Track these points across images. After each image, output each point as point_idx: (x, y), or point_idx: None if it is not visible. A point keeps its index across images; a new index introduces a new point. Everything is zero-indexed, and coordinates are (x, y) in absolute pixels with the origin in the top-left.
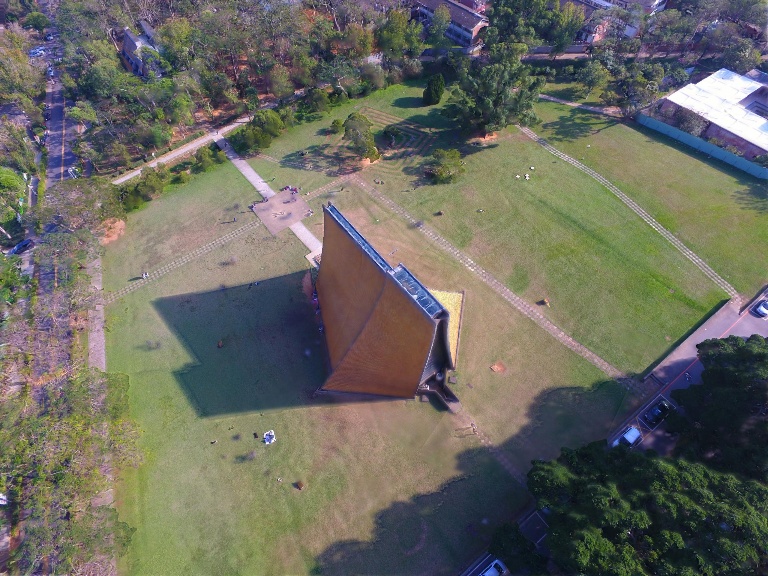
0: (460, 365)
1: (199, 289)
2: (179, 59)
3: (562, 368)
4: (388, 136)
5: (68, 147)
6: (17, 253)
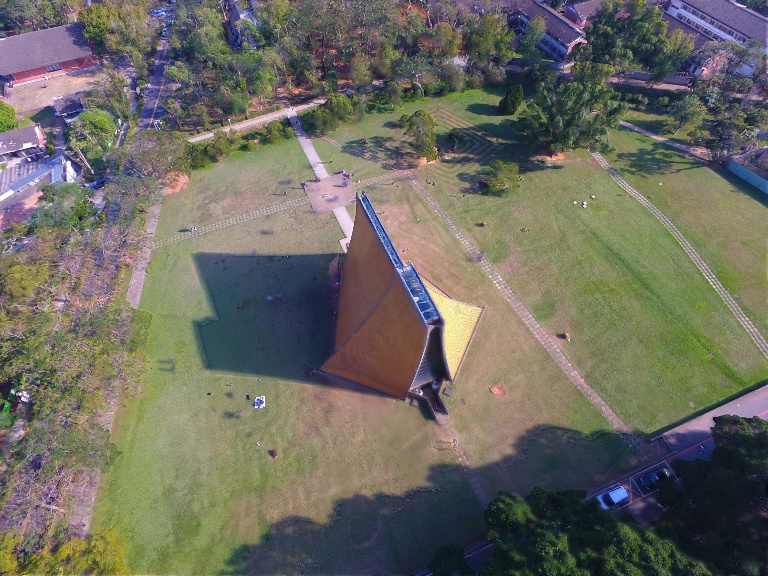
0: (459, 379)
1: (236, 251)
2: (274, 35)
3: (565, 407)
4: (452, 139)
5: (161, 102)
6: (95, 188)
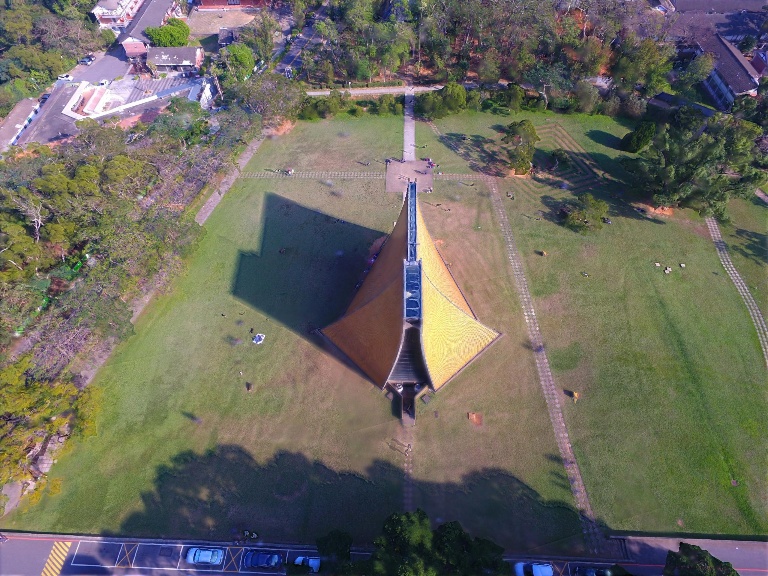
0: (443, 392)
1: (302, 202)
2: None
3: (535, 463)
4: (555, 159)
5: None
6: None
